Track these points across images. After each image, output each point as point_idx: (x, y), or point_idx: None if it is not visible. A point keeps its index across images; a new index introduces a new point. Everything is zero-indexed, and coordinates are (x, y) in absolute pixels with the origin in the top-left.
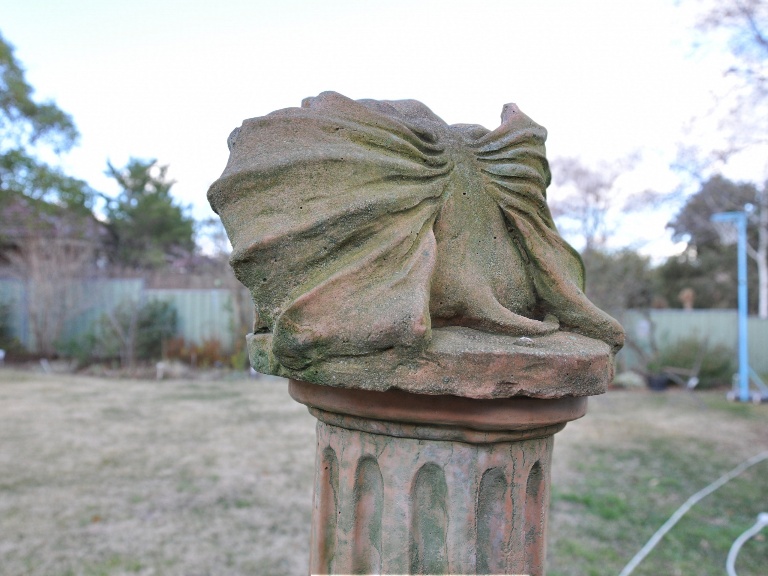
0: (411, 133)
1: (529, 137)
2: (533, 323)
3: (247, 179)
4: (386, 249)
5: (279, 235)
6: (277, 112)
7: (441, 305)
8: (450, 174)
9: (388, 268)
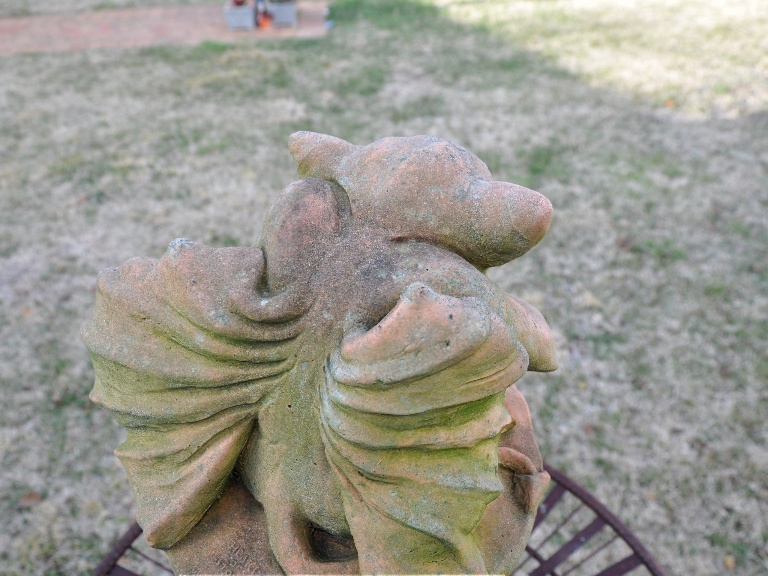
0: (226, 331)
1: (366, 384)
2: (294, 575)
3: None
4: (162, 453)
5: (100, 401)
6: (125, 268)
7: (252, 492)
8: (281, 377)
9: (168, 466)
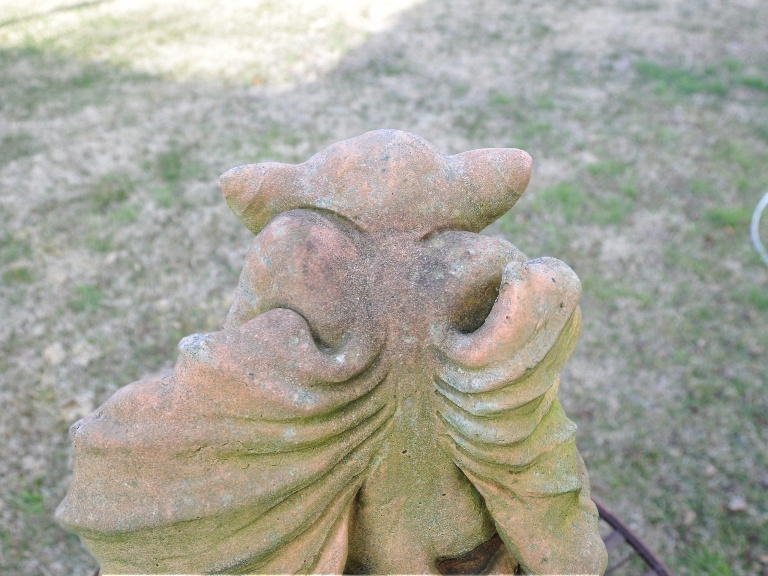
0: (319, 409)
1: (516, 379)
2: None
3: (88, 532)
4: None
5: None
6: (121, 407)
7: (361, 571)
8: (386, 427)
9: None
